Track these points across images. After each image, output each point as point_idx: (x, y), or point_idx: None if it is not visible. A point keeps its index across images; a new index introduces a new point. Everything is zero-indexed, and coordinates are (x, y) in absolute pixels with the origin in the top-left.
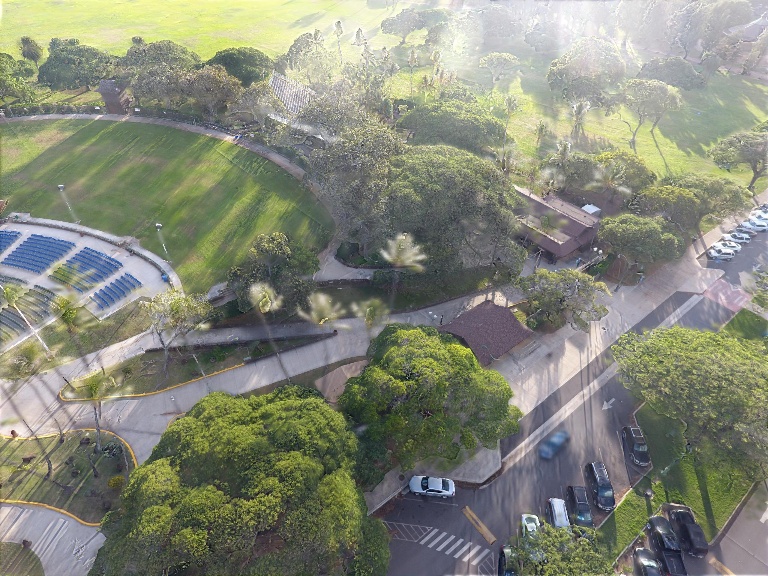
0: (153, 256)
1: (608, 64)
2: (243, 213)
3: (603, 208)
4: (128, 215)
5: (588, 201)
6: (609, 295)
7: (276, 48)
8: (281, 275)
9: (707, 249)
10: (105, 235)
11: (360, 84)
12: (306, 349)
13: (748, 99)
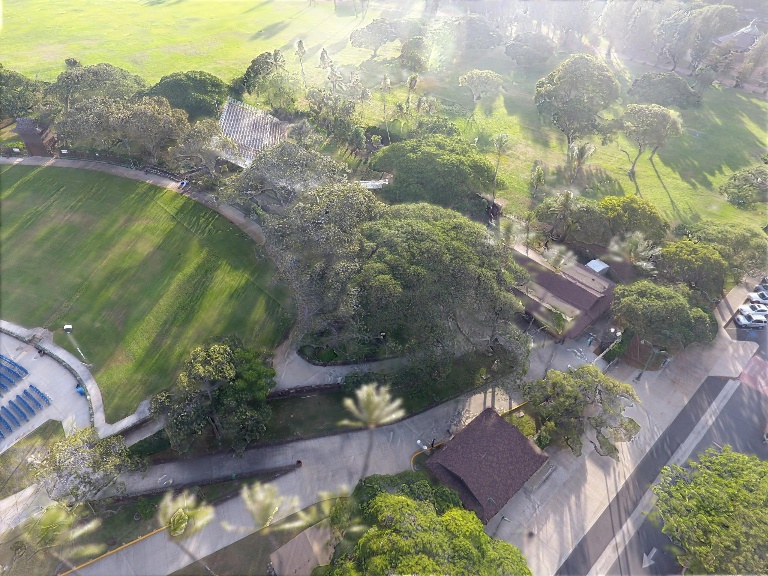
0: (68, 357)
1: (599, 83)
2: (185, 290)
3: (609, 261)
4: (42, 297)
5: (593, 254)
6: (638, 401)
7: (235, 64)
8: (223, 402)
9: (734, 314)
10: (10, 327)
11: (328, 110)
12: (261, 491)
13: (746, 116)
